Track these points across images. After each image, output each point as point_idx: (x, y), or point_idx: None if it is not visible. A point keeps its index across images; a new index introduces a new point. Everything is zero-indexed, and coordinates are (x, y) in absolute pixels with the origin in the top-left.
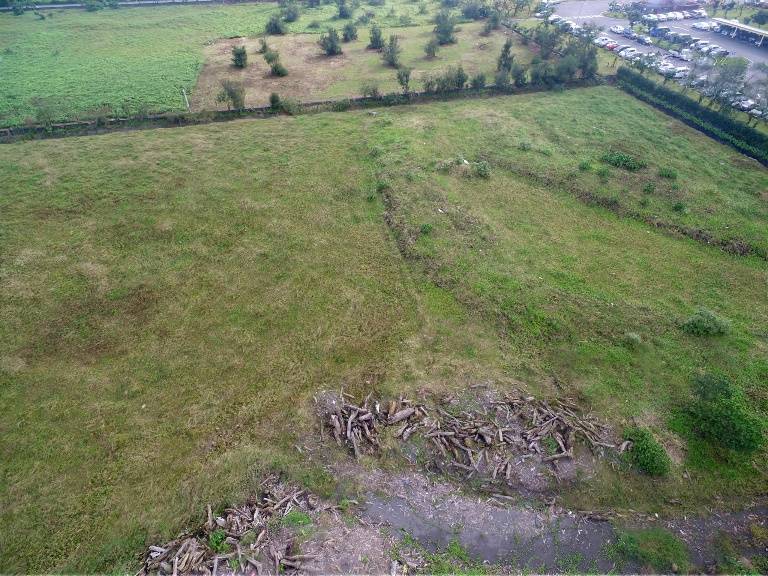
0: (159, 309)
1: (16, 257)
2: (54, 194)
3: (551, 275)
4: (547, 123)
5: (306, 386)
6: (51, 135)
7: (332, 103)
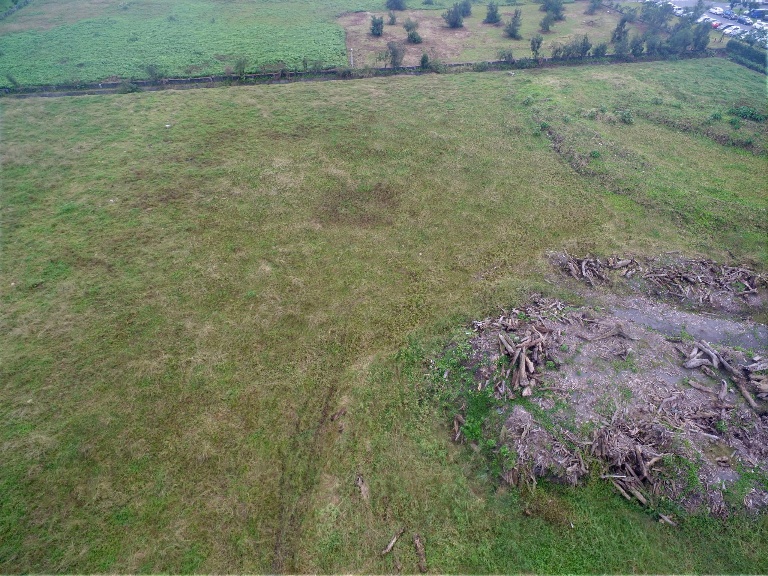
0: (401, 199)
1: (272, 163)
2: (275, 123)
3: (707, 190)
4: (671, 84)
5: (537, 248)
6: (244, 83)
7: (472, 65)
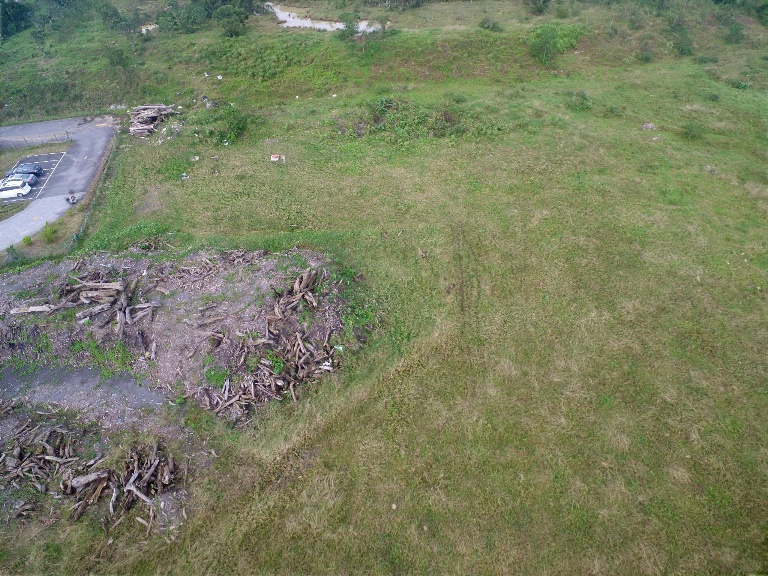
0: None
1: None
2: None
3: None
4: None
5: (193, 535)
6: None
7: None
